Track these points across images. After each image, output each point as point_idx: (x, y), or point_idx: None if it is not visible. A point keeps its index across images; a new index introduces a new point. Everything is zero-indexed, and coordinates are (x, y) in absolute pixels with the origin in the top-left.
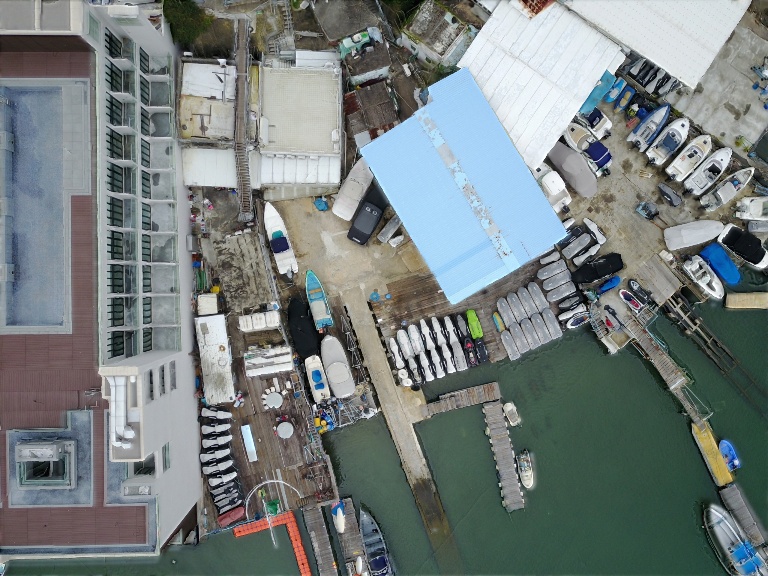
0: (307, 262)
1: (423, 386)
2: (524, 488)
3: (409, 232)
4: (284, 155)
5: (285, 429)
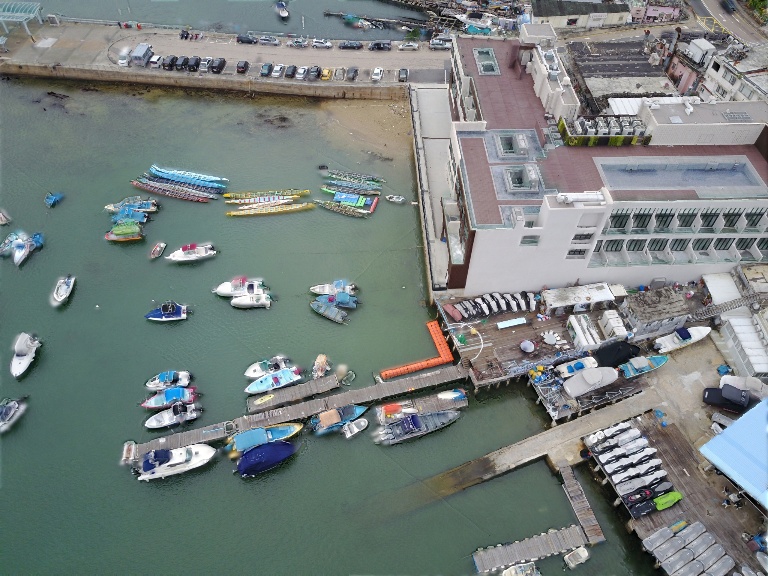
0: (669, 362)
1: (582, 467)
2: (502, 570)
3: (750, 412)
4: (761, 330)
5: (529, 346)
